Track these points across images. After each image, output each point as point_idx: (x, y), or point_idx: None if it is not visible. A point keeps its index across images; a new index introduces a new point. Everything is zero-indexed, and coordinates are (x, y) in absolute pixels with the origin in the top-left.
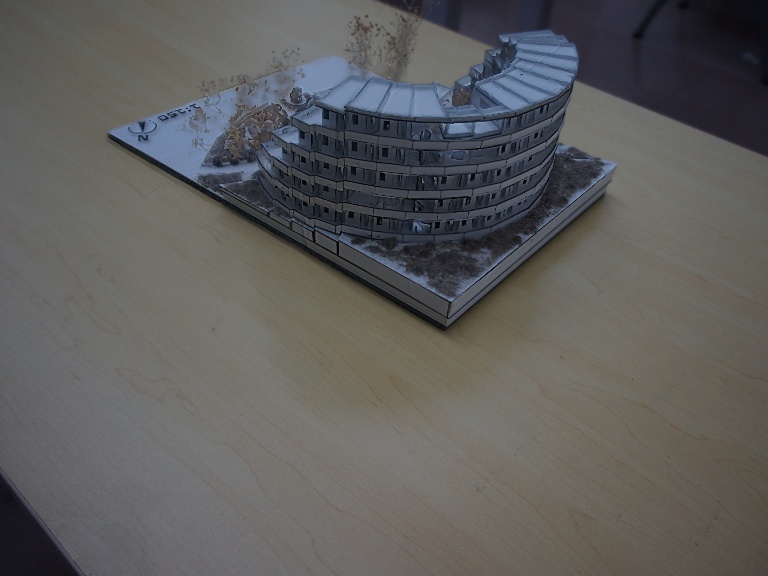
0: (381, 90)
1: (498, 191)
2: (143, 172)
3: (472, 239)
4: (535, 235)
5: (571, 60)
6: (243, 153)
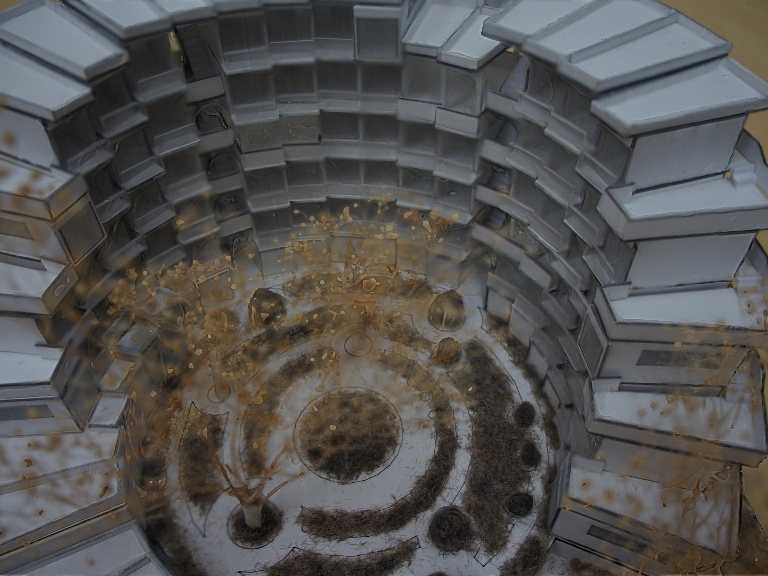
0: (604, 62)
1: None
2: None
3: None
4: None
5: None
6: None
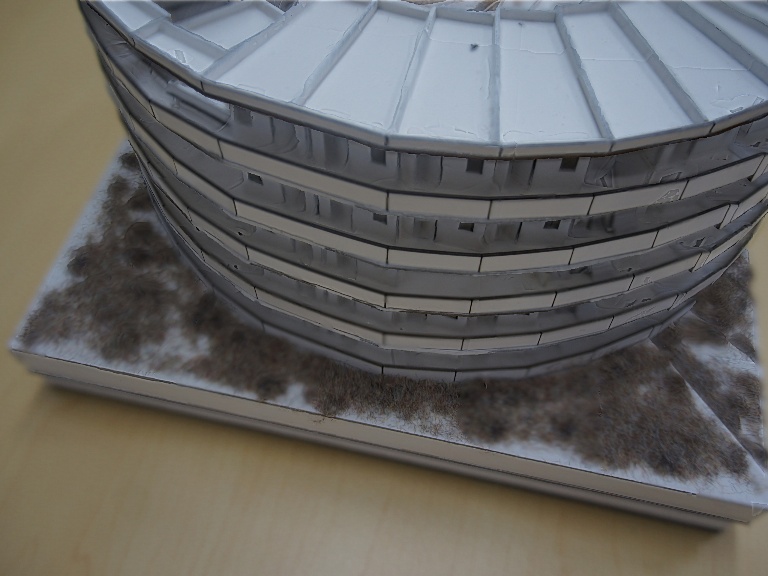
0: None
1: (244, 259)
2: None
3: (219, 308)
4: (328, 418)
5: (687, 114)
6: None
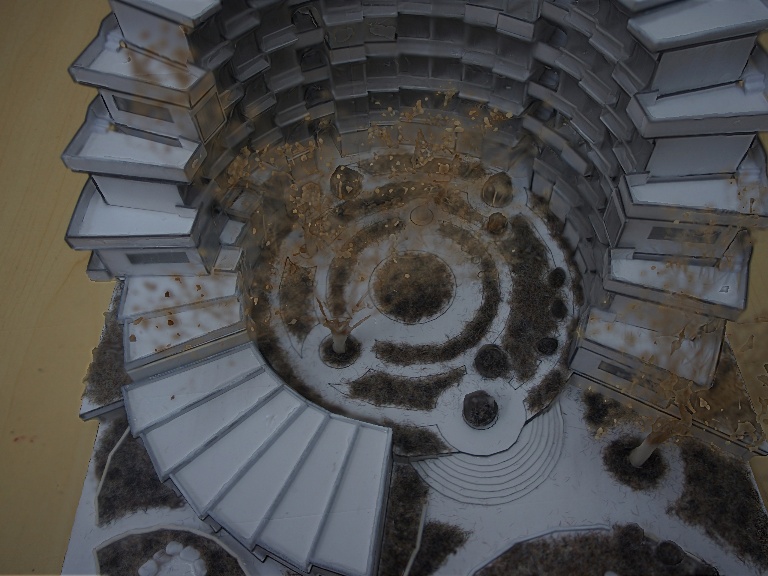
0: None
1: None
2: None
3: None
4: None
5: None
6: (631, 571)
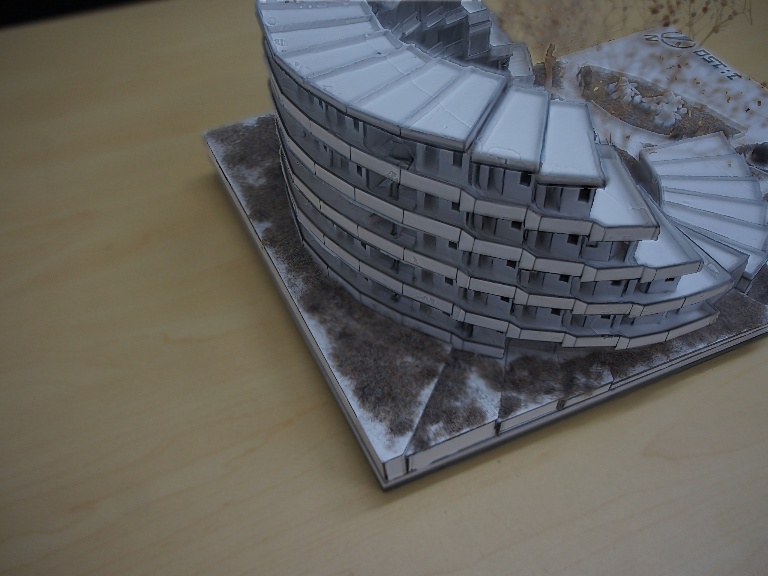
0: None
1: None
2: (591, 43)
3: None
4: None
5: None
6: (605, 93)
